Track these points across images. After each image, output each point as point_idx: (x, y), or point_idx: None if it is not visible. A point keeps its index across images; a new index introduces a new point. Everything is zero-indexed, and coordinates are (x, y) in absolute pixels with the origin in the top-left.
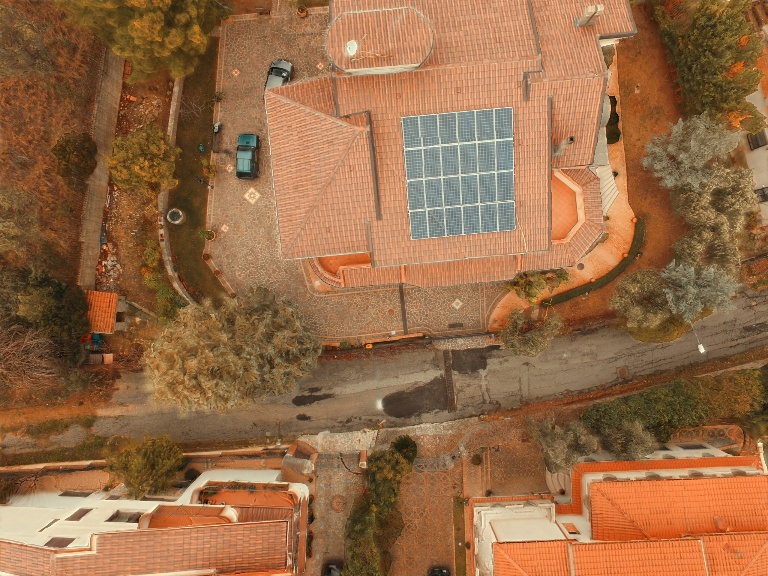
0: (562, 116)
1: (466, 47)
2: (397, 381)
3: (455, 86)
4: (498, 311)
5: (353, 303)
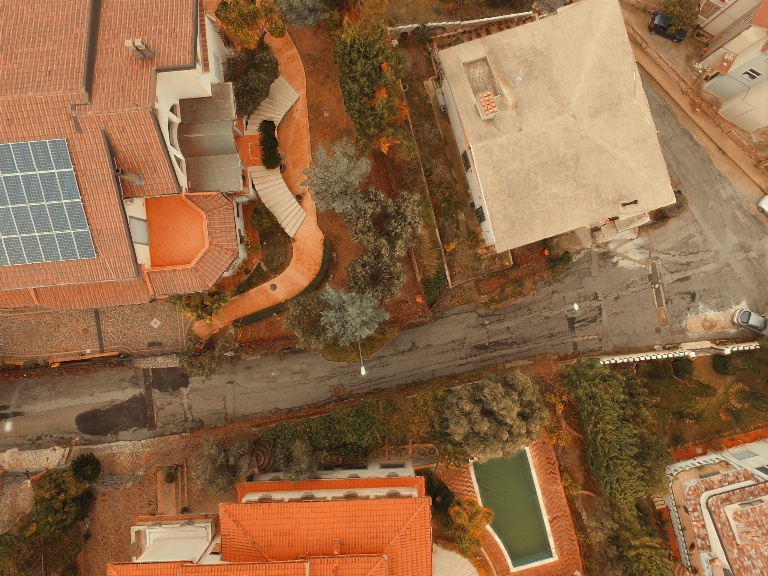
0: (125, 147)
1: (16, 80)
2: (92, 399)
3: (6, 118)
4: (196, 330)
5: (43, 322)
